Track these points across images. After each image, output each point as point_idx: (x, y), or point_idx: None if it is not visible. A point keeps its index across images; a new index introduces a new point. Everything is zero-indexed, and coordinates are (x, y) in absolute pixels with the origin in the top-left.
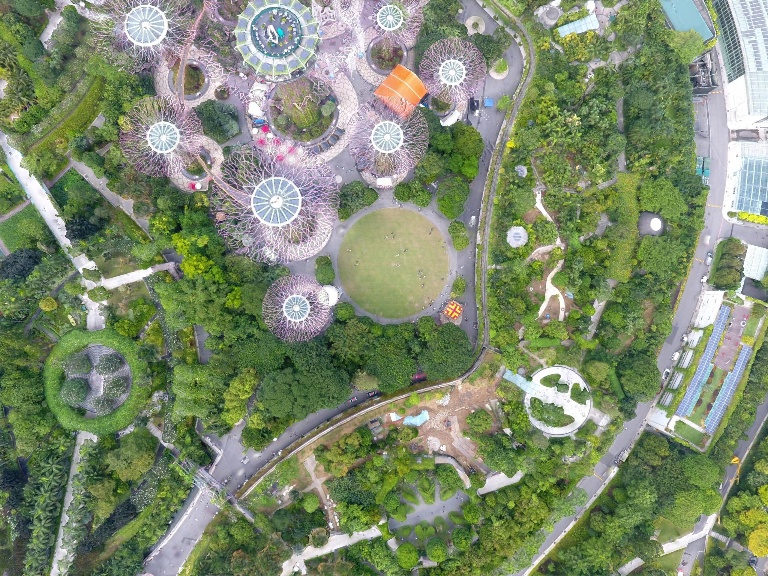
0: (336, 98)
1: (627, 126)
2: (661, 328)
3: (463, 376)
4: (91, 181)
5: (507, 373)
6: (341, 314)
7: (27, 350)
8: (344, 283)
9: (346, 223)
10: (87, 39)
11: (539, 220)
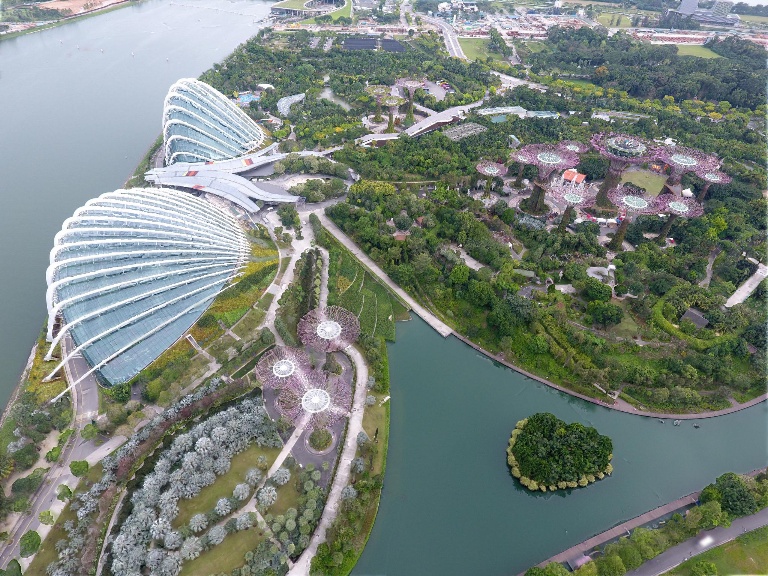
0: None
1: None
2: None
3: None
4: None
5: None
6: None
7: None
8: None
9: None
10: None
11: None
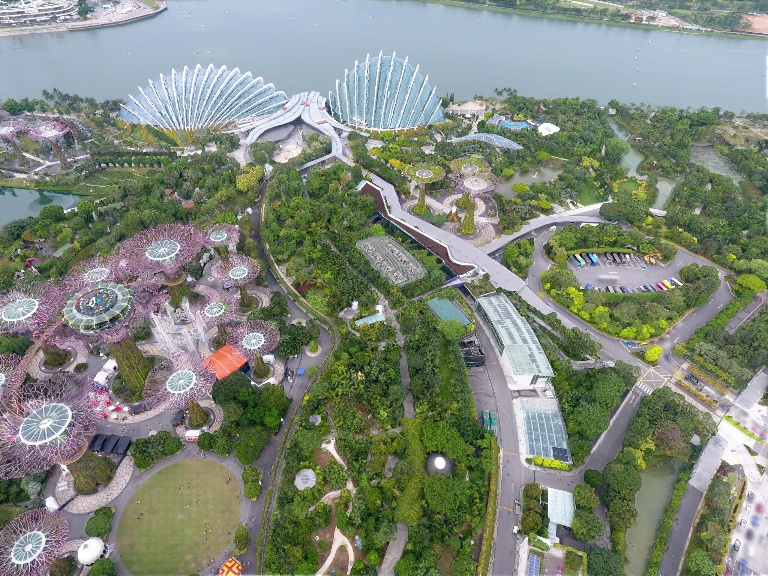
0: None
1: None
2: None
3: None
4: None
5: None
6: (93, 571)
7: None
8: (119, 539)
9: (145, 474)
10: None
11: (328, 462)
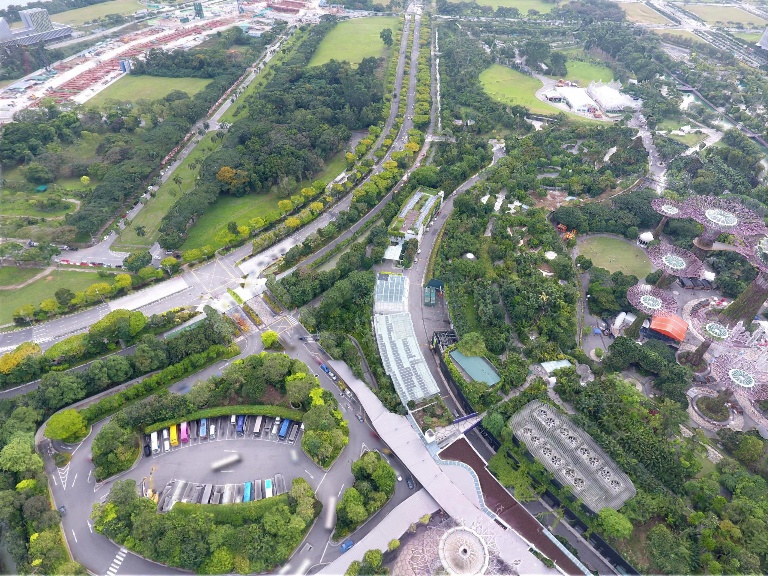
0: None
1: None
2: None
3: None
4: None
5: None
6: None
7: None
8: (638, 249)
9: None
10: None
11: (541, 261)
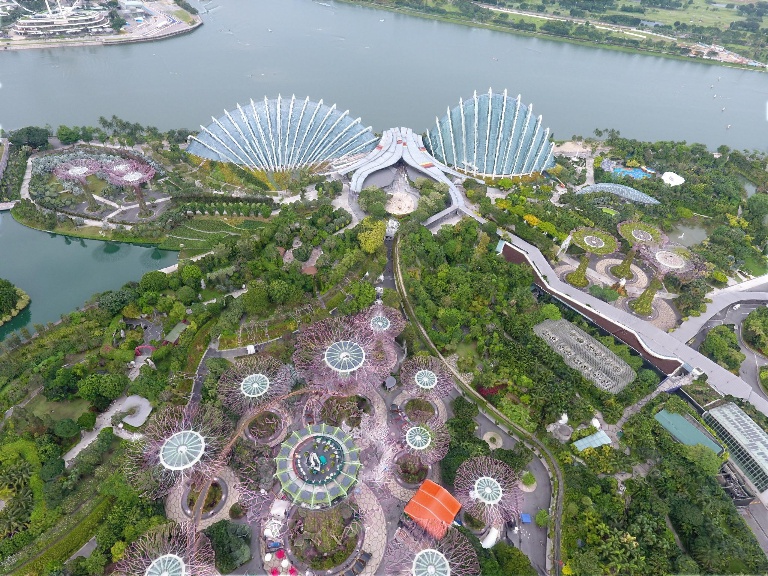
0: None
1: (687, 545)
2: None
3: None
4: None
5: None
6: None
7: None
8: None
9: None
10: (113, 458)
11: None
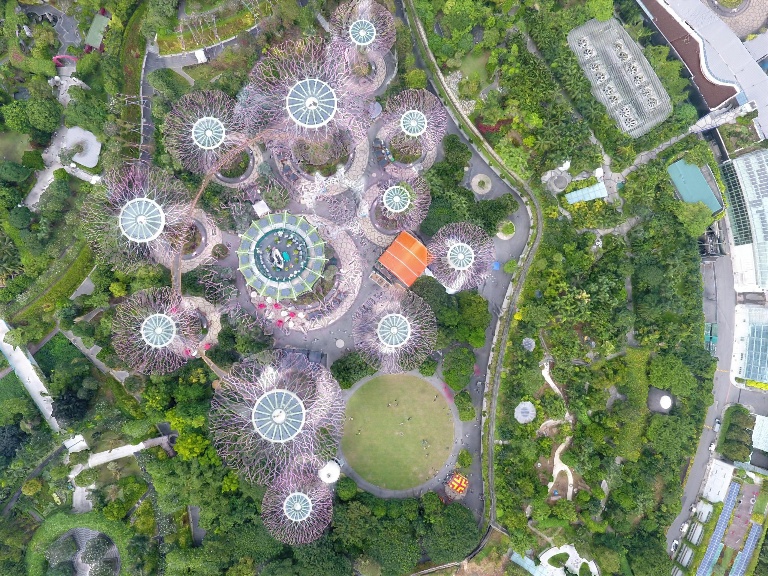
0: (338, 259)
1: (636, 297)
2: (671, 508)
3: (469, 555)
4: (80, 345)
5: (514, 555)
6: (343, 494)
7: (8, 543)
8: (345, 453)
9: (348, 389)
10: (78, 205)
11: (547, 395)
